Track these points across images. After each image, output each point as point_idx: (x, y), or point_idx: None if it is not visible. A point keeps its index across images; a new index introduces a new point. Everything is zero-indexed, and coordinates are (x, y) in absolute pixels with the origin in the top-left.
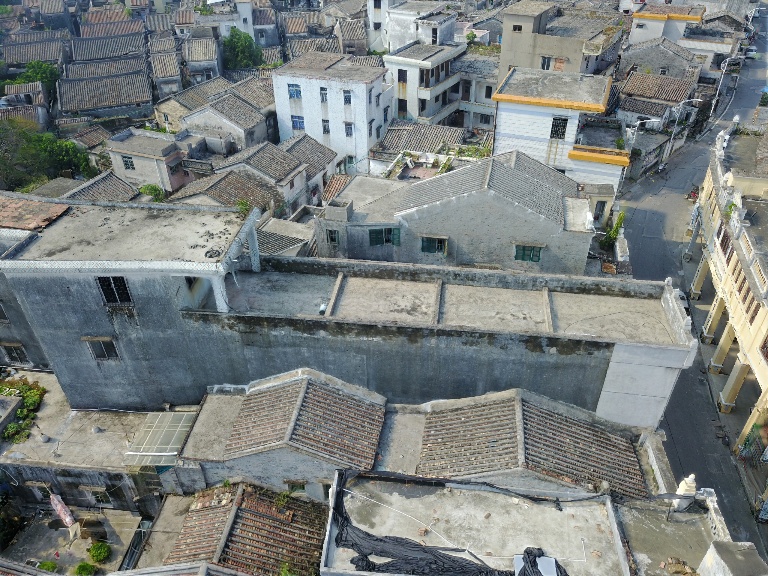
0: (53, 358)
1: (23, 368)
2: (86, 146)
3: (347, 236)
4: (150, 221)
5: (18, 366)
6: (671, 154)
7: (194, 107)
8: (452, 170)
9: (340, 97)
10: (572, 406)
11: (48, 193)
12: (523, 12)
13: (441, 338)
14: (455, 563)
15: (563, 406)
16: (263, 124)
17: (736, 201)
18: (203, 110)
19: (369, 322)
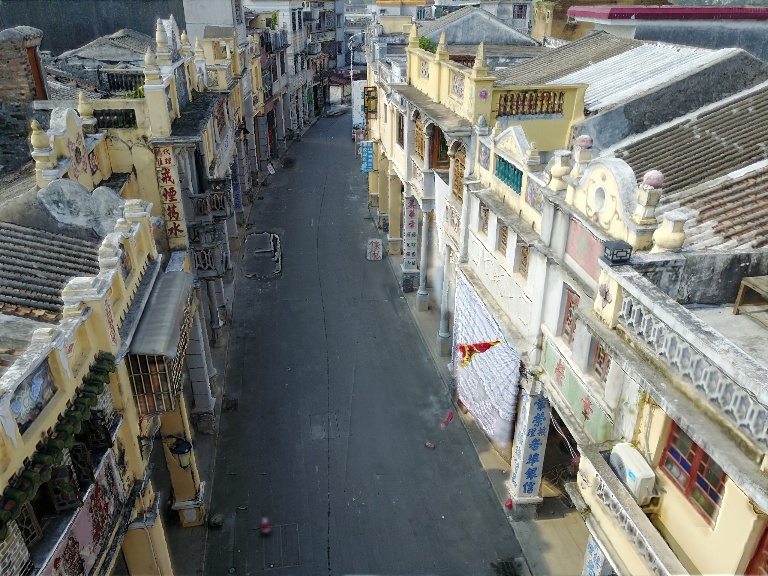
0: None
1: None
2: None
3: None
4: None
5: None
6: None
7: None
8: None
9: None
10: None
11: None
12: None
13: None
14: None
15: None
16: None
17: None
18: None
19: None
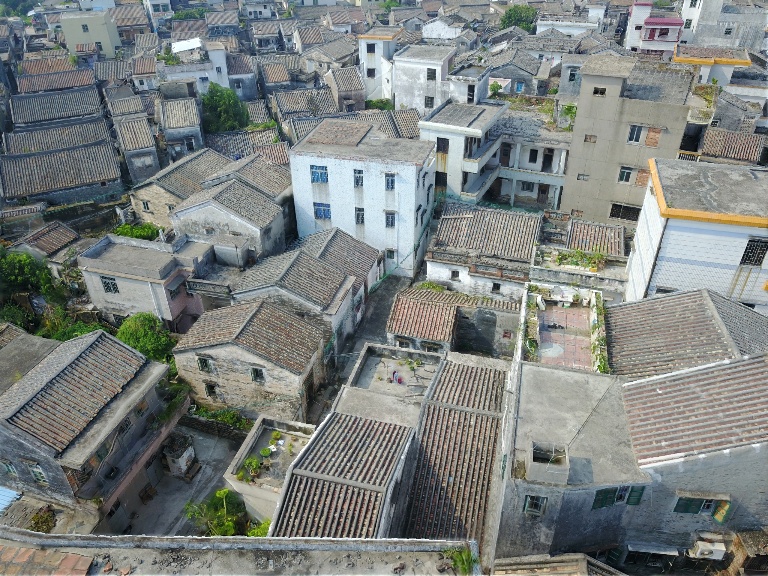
0: None
1: None
2: (44, 253)
3: (561, 504)
4: None
5: None
6: None
7: (184, 194)
8: (609, 315)
9: (380, 181)
10: None
11: (6, 368)
12: (608, 72)
13: None
14: None
15: None
16: (280, 216)
17: None
18: (203, 204)
19: None
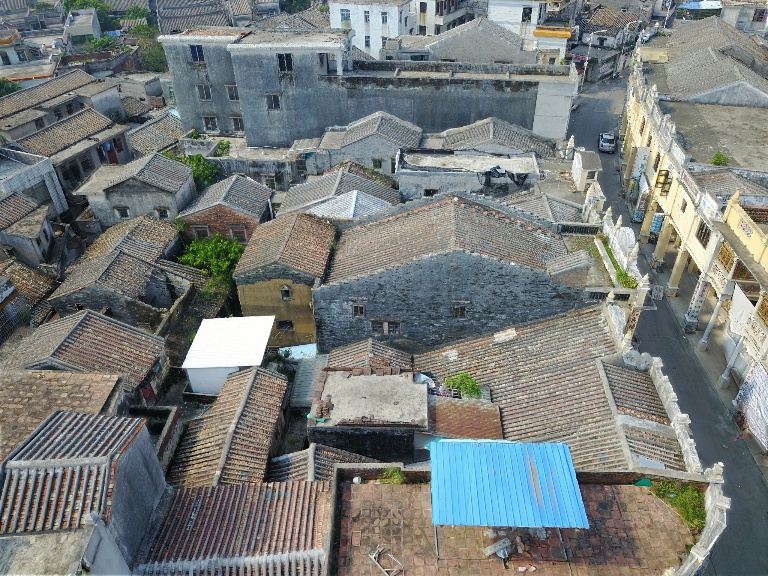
0: (245, 109)
1: (213, 135)
2: None
3: (398, 59)
4: (297, 35)
5: (210, 133)
6: (624, 68)
7: None
8: None
9: (379, 18)
10: (520, 127)
11: None
12: None
13: (452, 85)
14: (458, 171)
15: (515, 127)
16: None
17: (638, 59)
18: None
19: (415, 77)
